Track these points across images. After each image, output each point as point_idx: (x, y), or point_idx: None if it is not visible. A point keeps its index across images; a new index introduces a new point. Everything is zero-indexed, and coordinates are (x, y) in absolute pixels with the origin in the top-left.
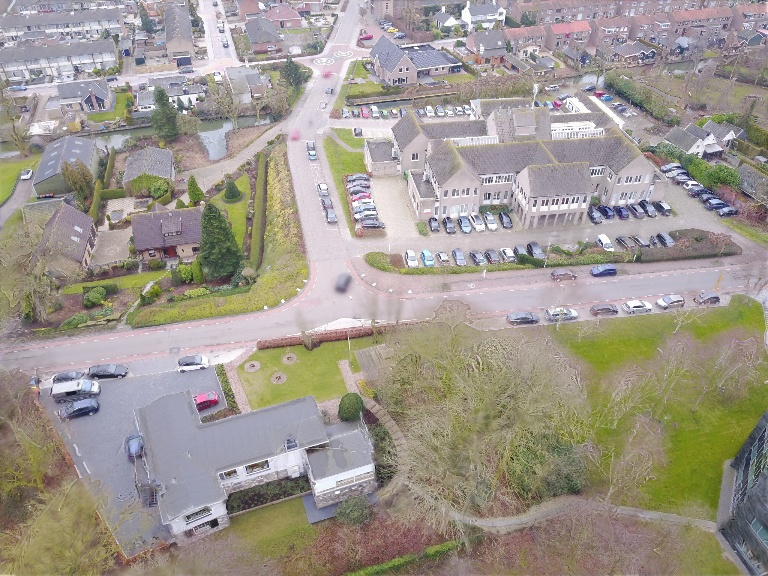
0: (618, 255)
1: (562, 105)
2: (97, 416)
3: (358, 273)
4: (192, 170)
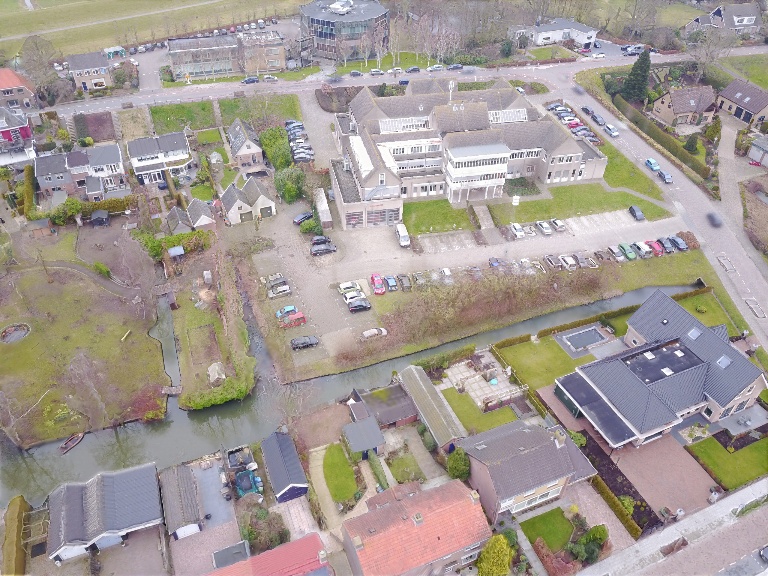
0: (394, 89)
1: None
2: (620, 49)
3: (548, 83)
4: (762, 174)
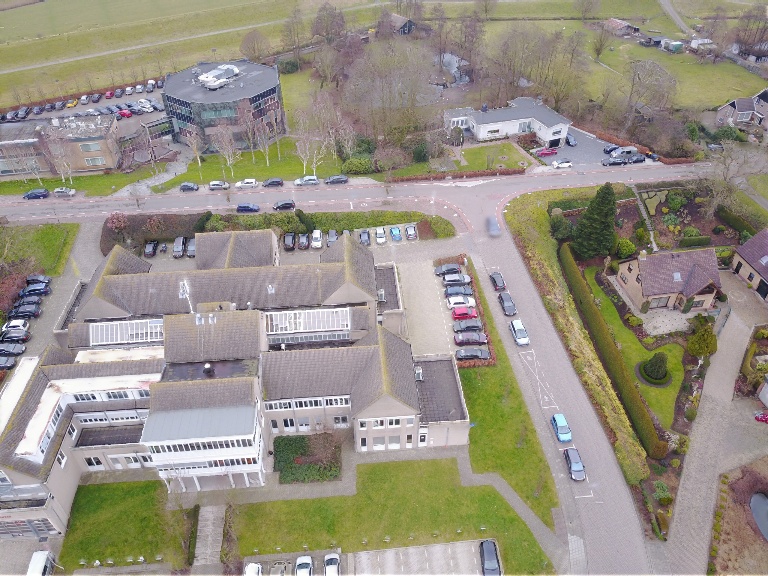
0: (222, 220)
1: (41, 475)
2: None
3: (460, 217)
4: None
